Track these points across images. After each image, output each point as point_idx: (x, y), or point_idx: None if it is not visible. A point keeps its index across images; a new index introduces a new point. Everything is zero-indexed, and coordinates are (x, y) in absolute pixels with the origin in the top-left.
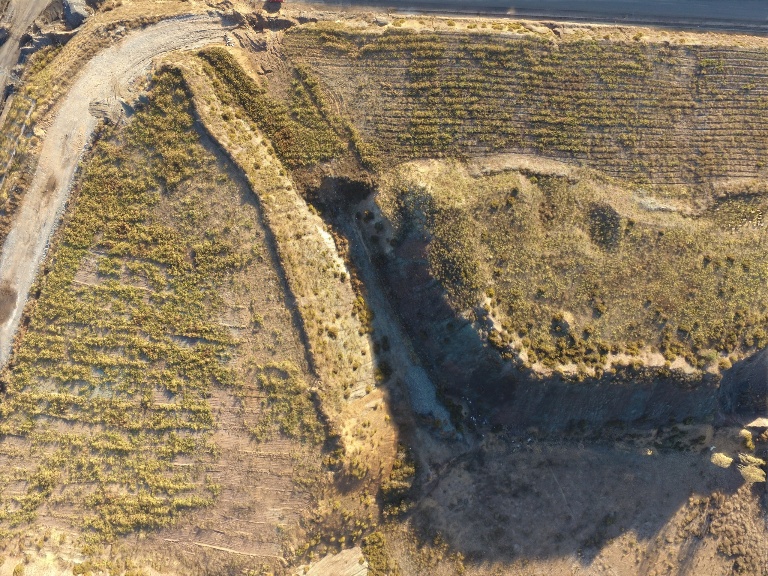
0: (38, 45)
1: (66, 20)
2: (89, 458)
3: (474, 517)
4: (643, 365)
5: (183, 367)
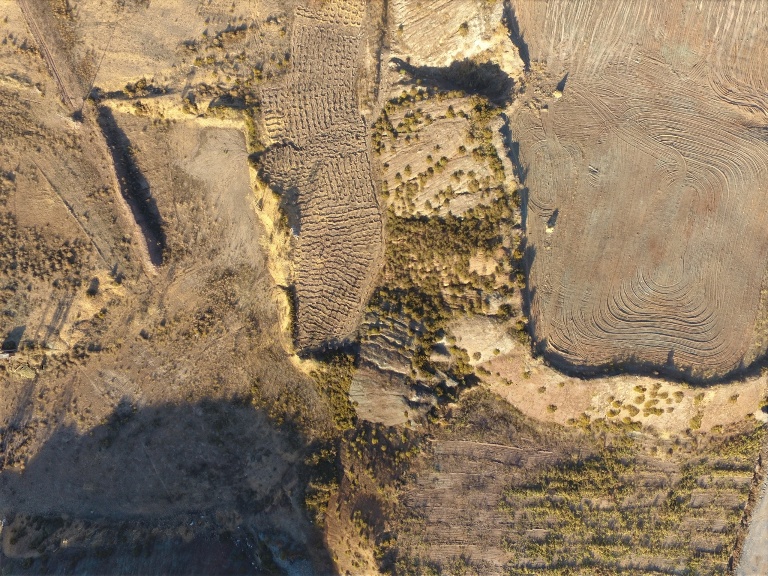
0: None
1: None
2: (632, 533)
3: (244, 443)
4: None
5: None
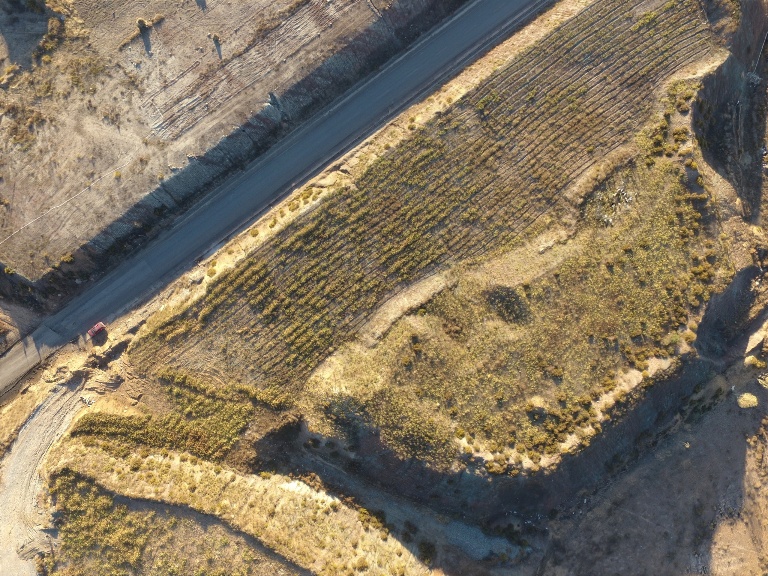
0: None
1: None
2: None
3: None
4: (627, 393)
5: None
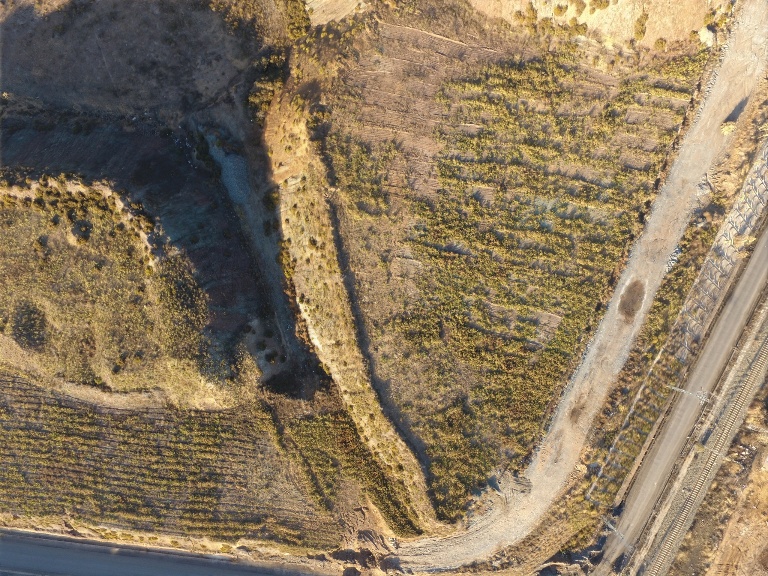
0: (584, 553)
1: (555, 575)
2: (563, 140)
3: (196, 46)
4: None
5: (462, 223)
